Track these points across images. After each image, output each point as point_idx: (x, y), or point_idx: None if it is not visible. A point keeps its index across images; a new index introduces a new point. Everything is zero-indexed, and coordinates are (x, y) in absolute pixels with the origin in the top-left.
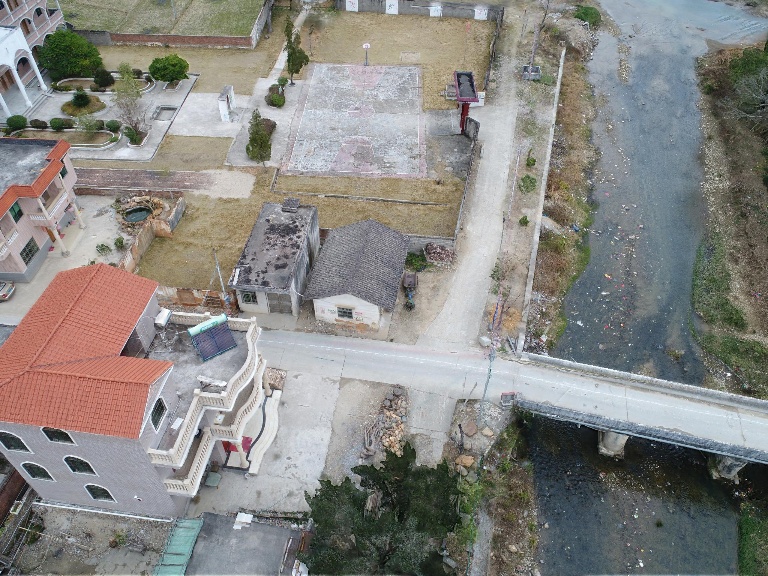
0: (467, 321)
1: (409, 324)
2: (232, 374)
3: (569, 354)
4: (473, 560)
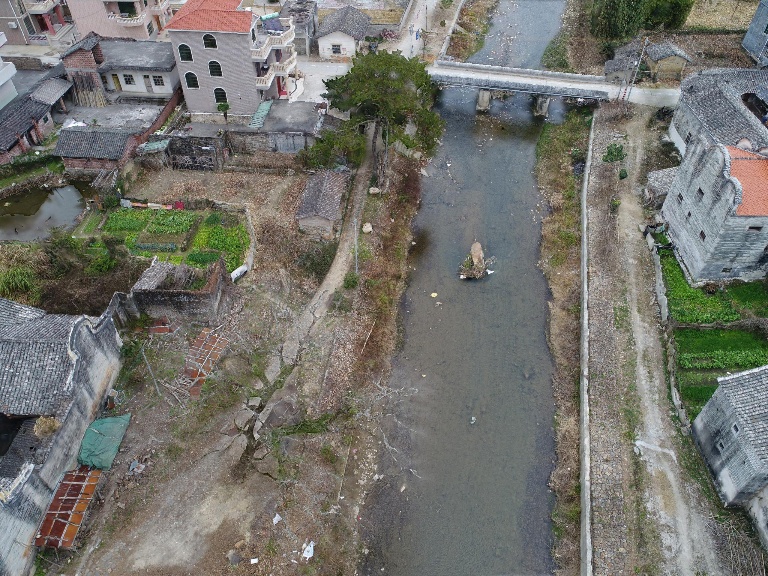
0: None
1: None
2: None
3: None
4: (405, 131)
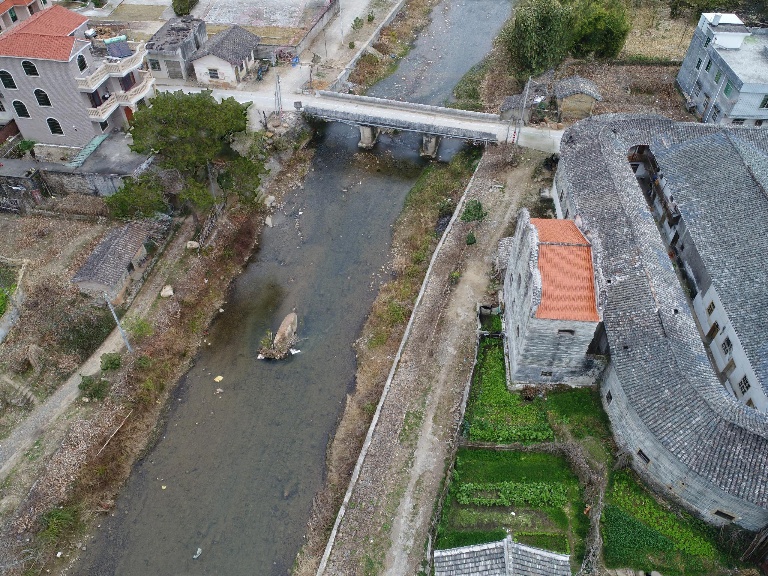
0: (293, 85)
1: (256, 86)
2: None
3: None
4: None
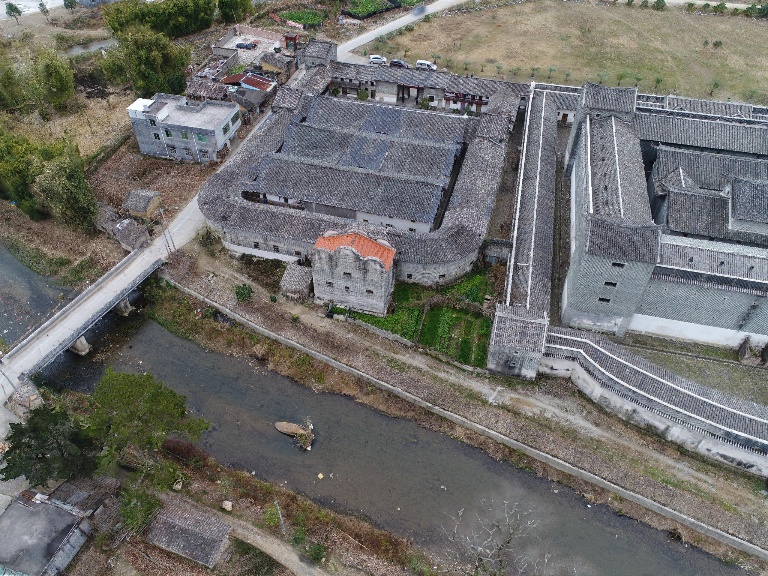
0: None
1: None
2: None
3: None
4: None
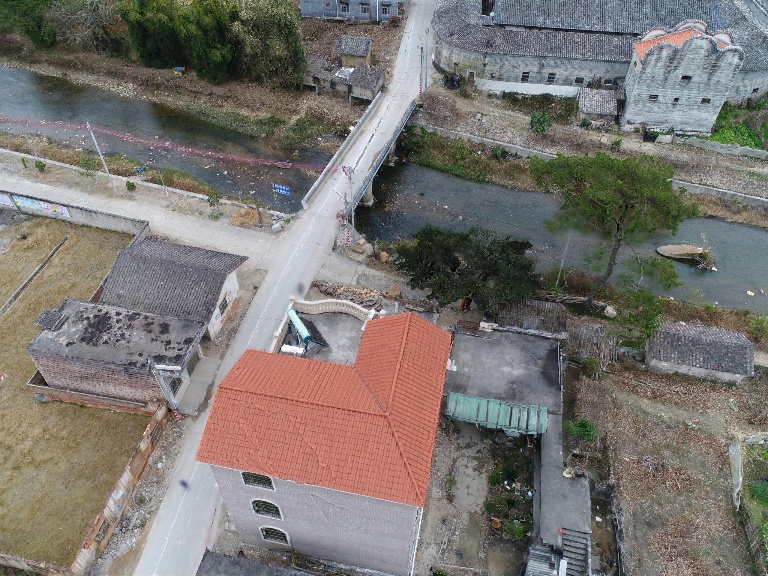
0: (247, 238)
1: (239, 275)
2: (347, 324)
3: (281, 204)
4: None
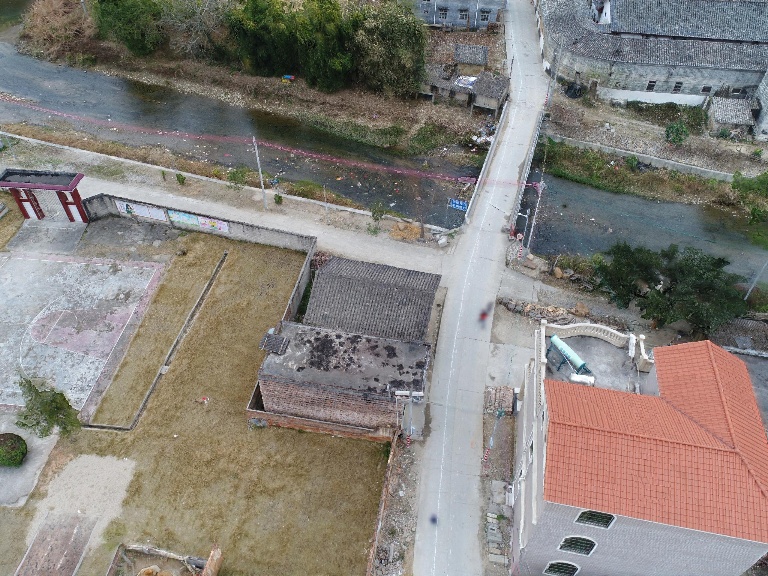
0: (414, 253)
1: None
2: (600, 348)
3: (425, 217)
4: None
